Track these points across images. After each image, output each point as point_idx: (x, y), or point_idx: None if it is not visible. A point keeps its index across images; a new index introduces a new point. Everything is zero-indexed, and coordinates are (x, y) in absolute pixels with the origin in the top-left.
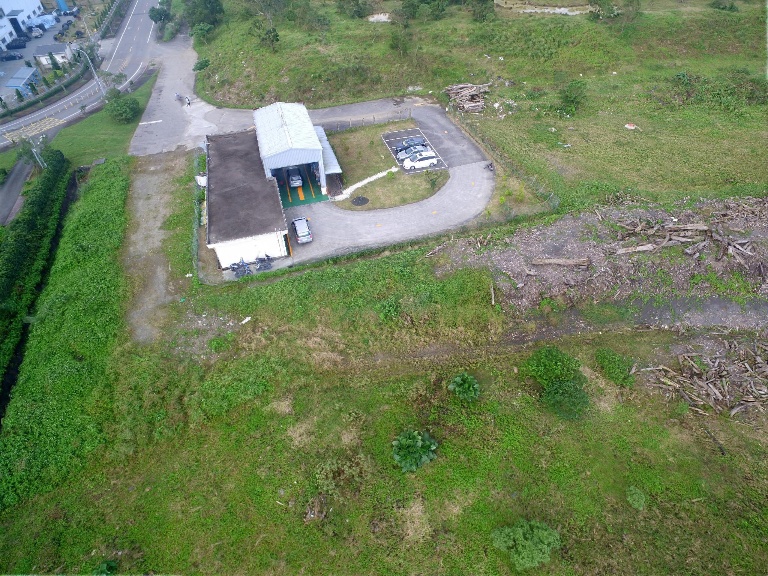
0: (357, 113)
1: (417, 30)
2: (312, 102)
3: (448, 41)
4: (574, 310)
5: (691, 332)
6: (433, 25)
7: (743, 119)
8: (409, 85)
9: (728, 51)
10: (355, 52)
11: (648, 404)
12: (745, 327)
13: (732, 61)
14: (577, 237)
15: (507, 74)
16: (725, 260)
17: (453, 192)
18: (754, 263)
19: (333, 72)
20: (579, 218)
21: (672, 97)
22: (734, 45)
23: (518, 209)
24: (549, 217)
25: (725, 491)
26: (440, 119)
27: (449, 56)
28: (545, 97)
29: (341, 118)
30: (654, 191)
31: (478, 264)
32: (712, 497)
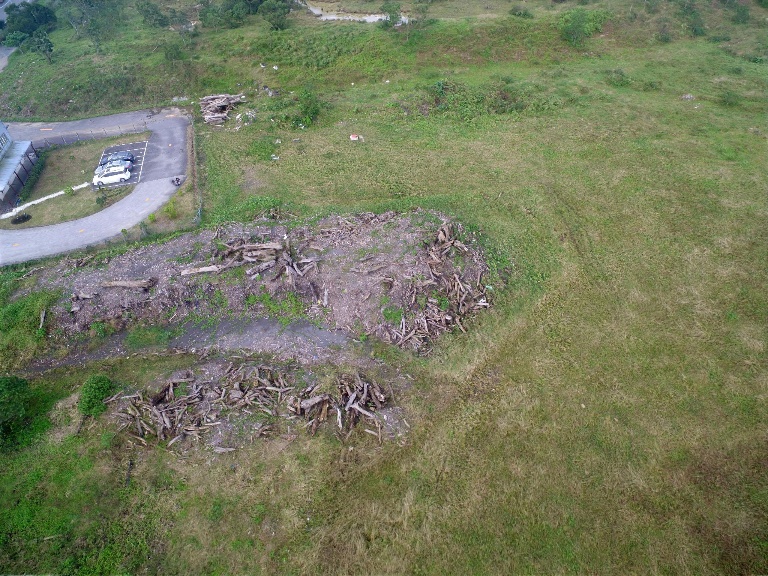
0: (103, 125)
1: (203, 39)
2: (66, 114)
3: (229, 50)
4: (123, 334)
5: (214, 356)
6: (224, 34)
7: (470, 129)
8: (174, 96)
9: (513, 58)
10: (128, 62)
11: (98, 434)
12: (267, 350)
13: (512, 68)
14: (173, 257)
15: (275, 84)
16: (280, 280)
17: (119, 209)
18: (305, 283)
19: (91, 83)
20: (196, 236)
21: (420, 106)
22: (520, 52)
23: (165, 226)
24: (172, 235)
25: (88, 527)
26: (177, 131)
27: (222, 66)
28: (290, 108)
29: (83, 131)
30: (314, 206)
31: (57, 287)
32: (68, 534)
